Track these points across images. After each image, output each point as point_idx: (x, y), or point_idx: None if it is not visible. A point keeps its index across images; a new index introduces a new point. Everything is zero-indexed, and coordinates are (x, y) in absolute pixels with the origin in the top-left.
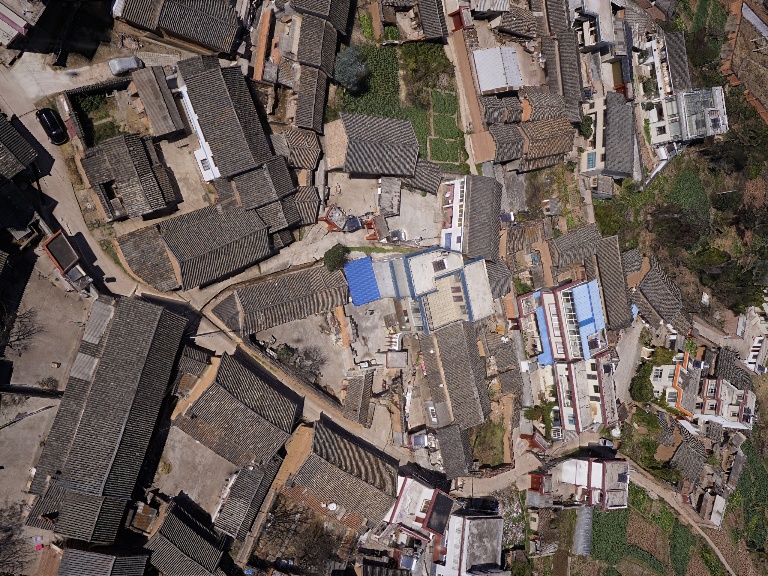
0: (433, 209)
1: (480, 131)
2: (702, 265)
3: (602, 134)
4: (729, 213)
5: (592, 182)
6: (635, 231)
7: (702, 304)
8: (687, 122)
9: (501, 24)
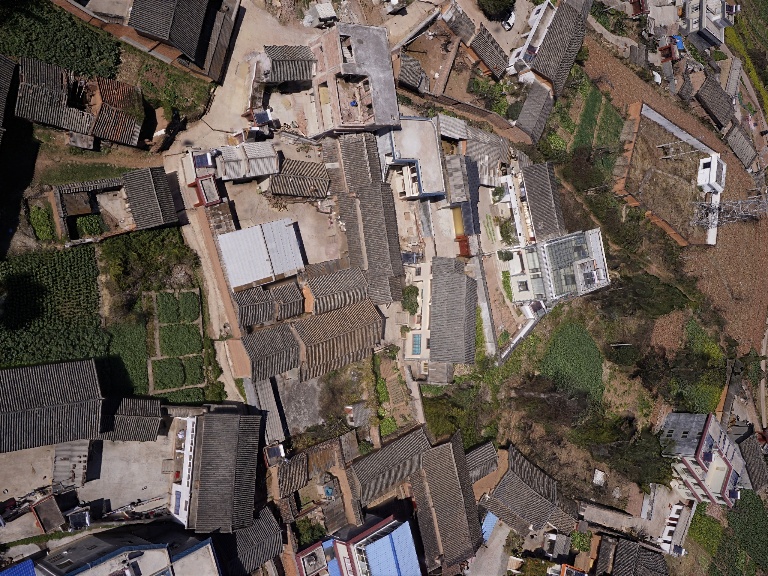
0: (161, 455)
1: (238, 336)
2: (589, 441)
3: (428, 311)
4: (628, 366)
5: (423, 368)
6: (494, 413)
7: (595, 483)
8: (551, 280)
9: (270, 189)
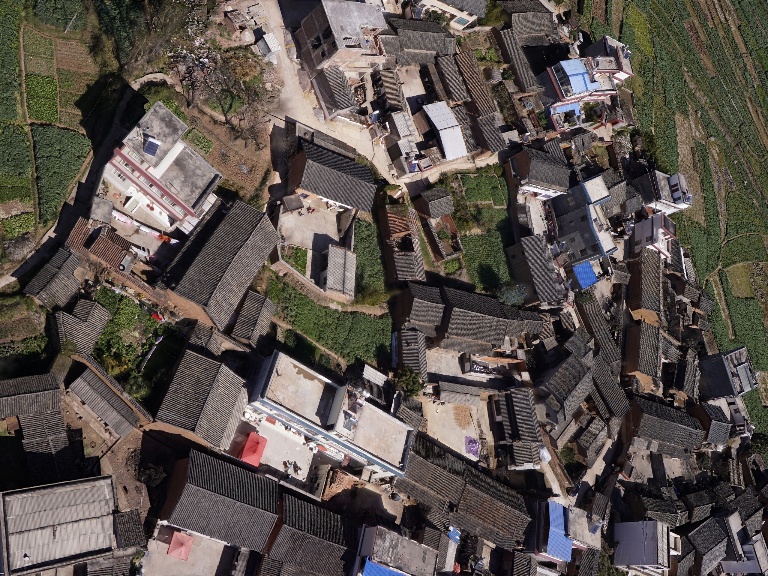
0: None
1: (476, 152)
2: None
3: (452, 8)
4: None
5: None
6: None
7: None
8: None
9: None
